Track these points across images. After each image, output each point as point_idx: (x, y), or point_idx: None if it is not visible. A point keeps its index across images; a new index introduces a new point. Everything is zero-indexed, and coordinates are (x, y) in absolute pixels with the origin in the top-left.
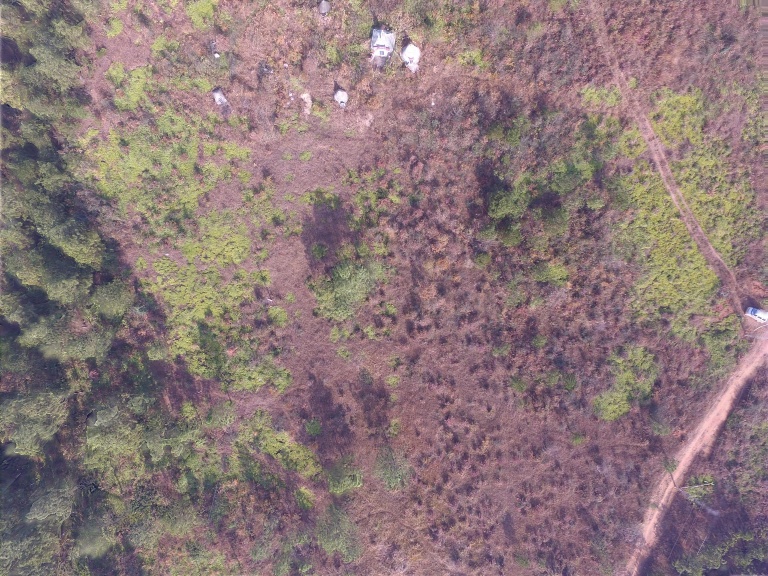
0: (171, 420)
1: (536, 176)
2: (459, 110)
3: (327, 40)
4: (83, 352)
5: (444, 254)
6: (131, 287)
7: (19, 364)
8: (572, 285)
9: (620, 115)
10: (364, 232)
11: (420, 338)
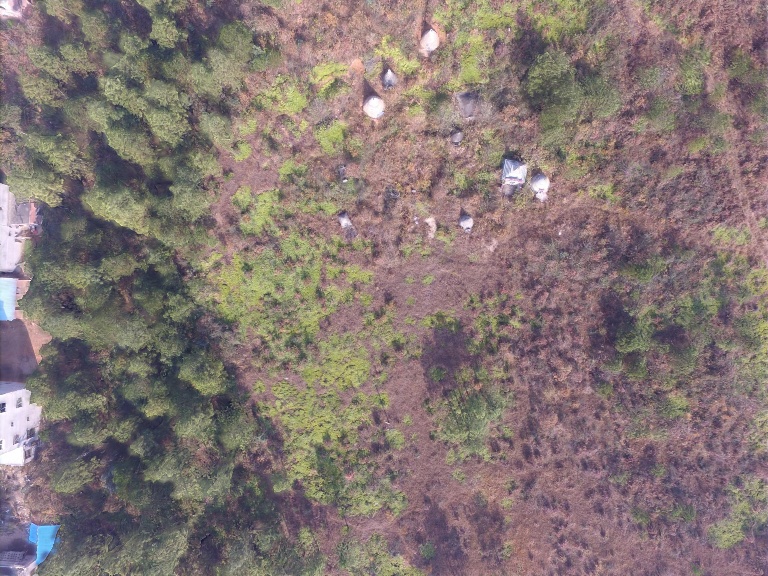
0: (288, 547)
1: (662, 309)
2: (589, 243)
3: (456, 167)
4: (196, 474)
5: (566, 382)
6: (248, 410)
7: (143, 499)
8: (692, 416)
9: (749, 254)
10: (483, 356)
11: (537, 463)
